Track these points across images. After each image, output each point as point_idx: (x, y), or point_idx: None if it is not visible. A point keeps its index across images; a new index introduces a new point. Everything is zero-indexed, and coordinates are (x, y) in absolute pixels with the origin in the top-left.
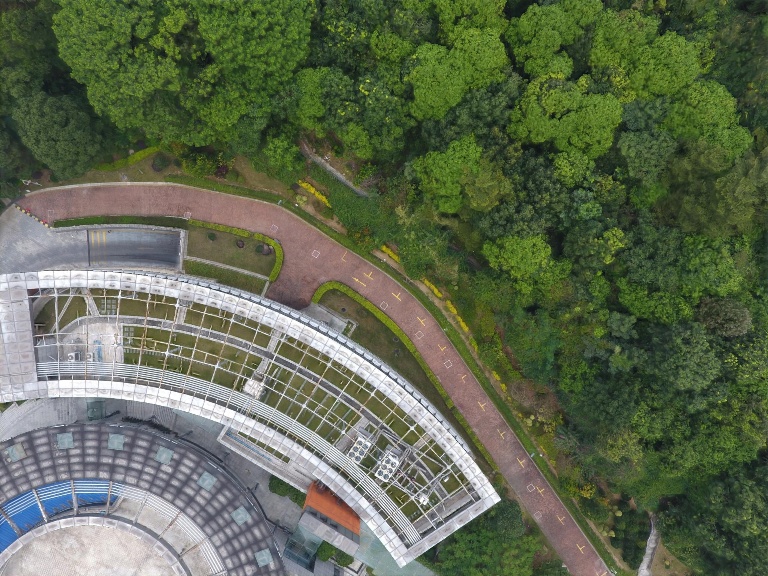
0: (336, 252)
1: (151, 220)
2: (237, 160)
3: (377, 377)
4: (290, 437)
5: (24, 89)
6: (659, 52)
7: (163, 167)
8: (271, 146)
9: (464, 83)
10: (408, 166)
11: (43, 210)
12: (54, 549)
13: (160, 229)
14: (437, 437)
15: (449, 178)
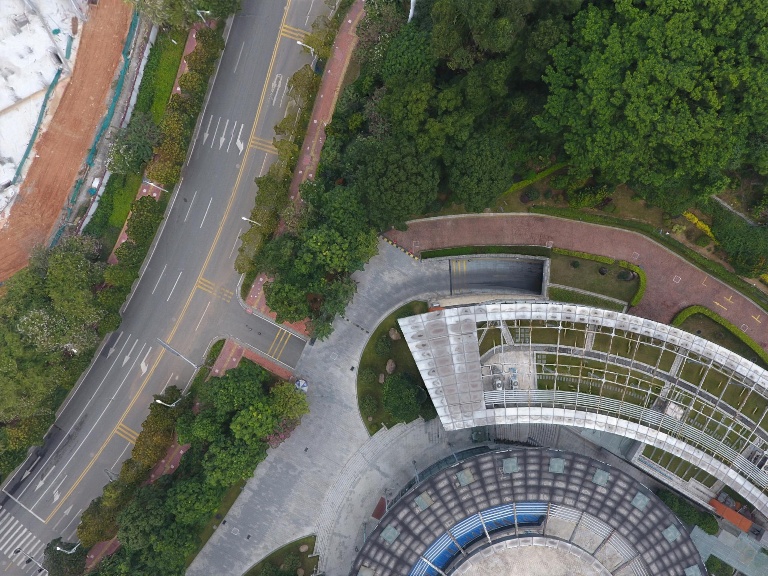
0: (697, 277)
1: (517, 249)
2: (615, 192)
3: None
4: (717, 458)
5: (468, 132)
6: None
7: None
8: (718, 183)
9: None
10: None
11: (409, 241)
12: (481, 568)
13: (526, 258)
14: None
15: None
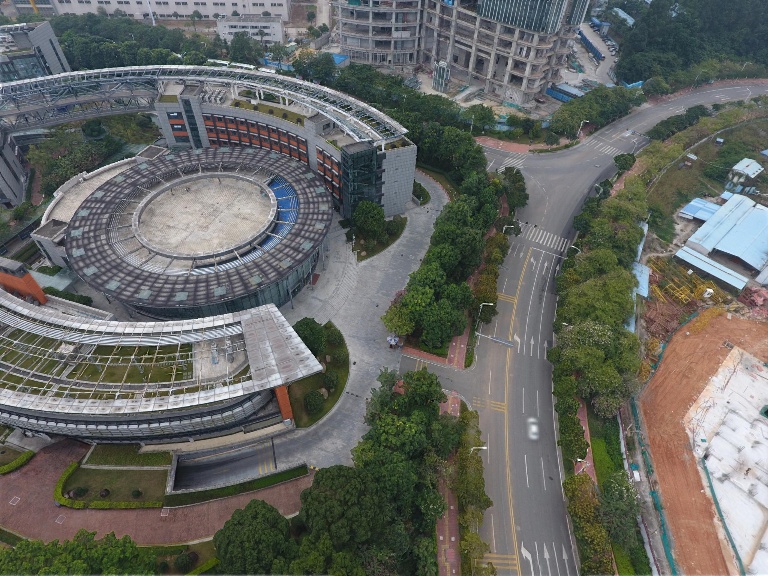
0: None
1: (204, 497)
2: None
3: None
4: (36, 320)
5: None
6: None
7: None
8: None
9: None
10: None
11: None
12: None
13: None
14: None
15: None
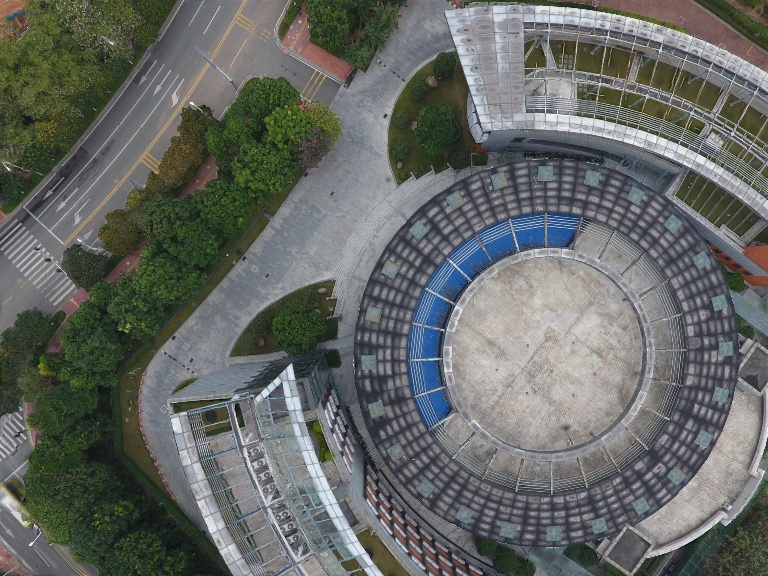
0: (742, 46)
1: (562, 4)
2: None
3: None
4: (754, 188)
5: None
6: None
7: None
8: None
9: None
10: None
11: None
12: (504, 288)
13: None
14: None
15: None
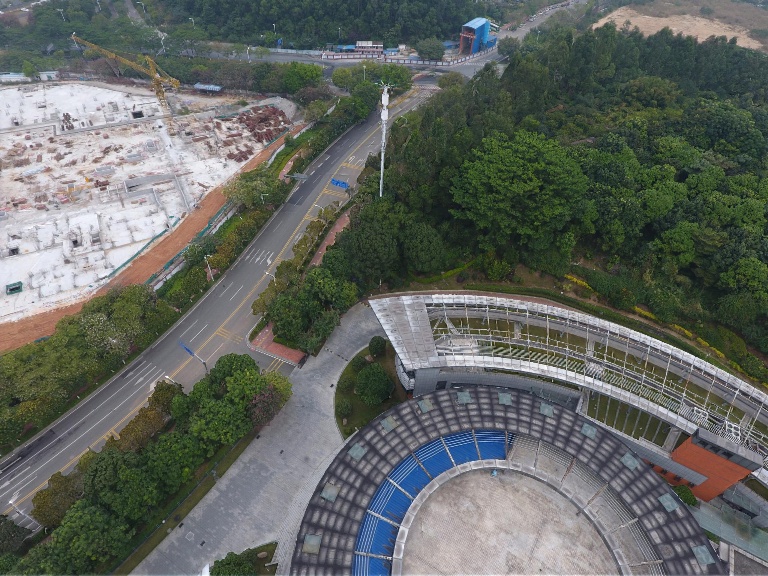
0: None
1: None
2: (518, 270)
3: (689, 357)
4: (643, 397)
5: None
6: (767, 182)
7: (467, 278)
8: (567, 236)
9: (672, 200)
10: (650, 244)
11: None
12: (451, 511)
13: None
14: (761, 399)
15: (685, 237)
